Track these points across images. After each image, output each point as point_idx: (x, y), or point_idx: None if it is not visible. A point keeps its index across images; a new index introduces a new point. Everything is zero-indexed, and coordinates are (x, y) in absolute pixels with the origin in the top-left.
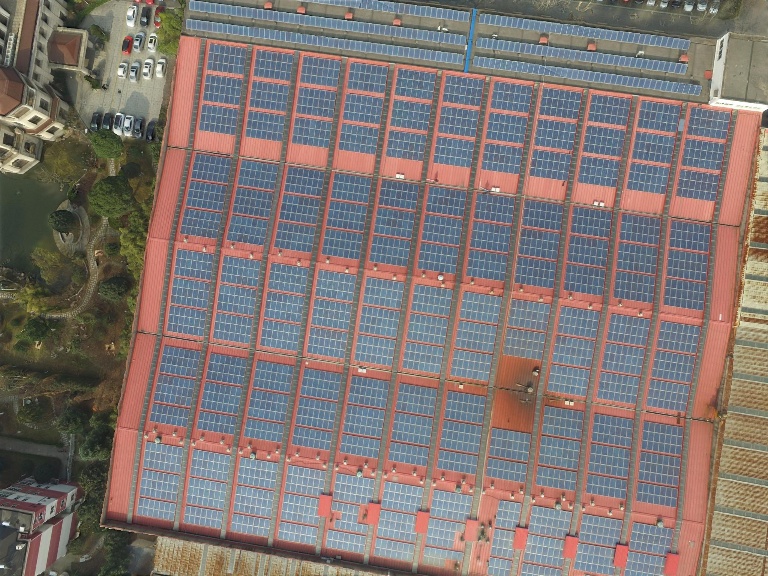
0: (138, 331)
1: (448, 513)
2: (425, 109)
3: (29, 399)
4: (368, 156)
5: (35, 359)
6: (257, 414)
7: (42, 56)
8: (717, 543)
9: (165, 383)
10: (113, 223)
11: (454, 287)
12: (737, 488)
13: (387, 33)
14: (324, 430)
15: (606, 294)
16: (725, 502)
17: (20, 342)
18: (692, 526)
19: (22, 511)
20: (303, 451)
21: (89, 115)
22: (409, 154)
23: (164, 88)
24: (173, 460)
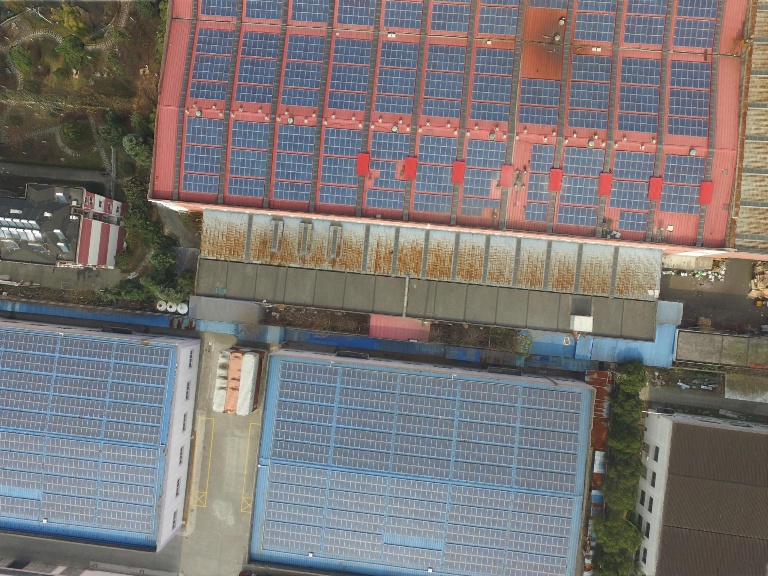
0: (173, 17)
1: (483, 161)
2: None
3: None
4: None
5: None
6: (292, 83)
7: None
8: (750, 170)
9: (202, 62)
10: None
11: None
12: (767, 114)
13: None
14: (358, 93)
15: None
16: (756, 130)
17: (59, 68)
18: (724, 154)
19: None
20: (339, 114)
21: None
22: None
23: None
24: (214, 133)
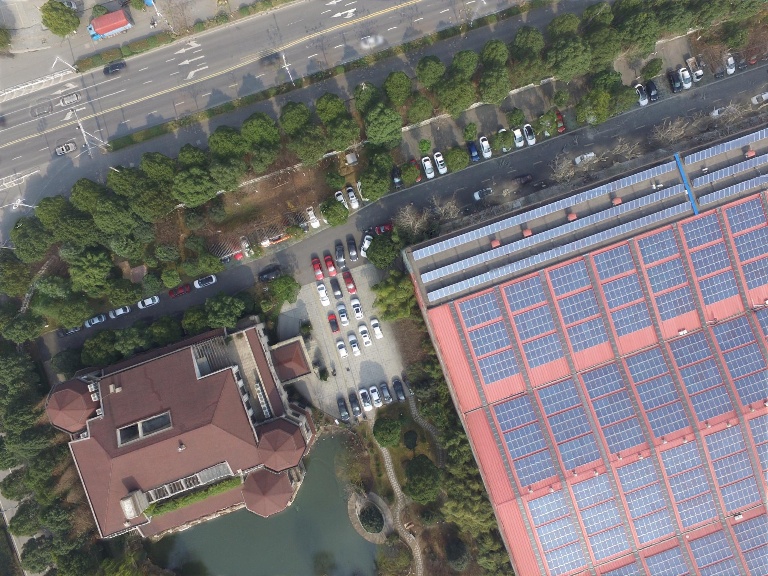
0: None
1: None
2: (677, 264)
3: None
4: (646, 329)
5: None
6: None
7: (278, 383)
8: None
9: None
10: None
11: None
12: None
13: (612, 214)
14: None
15: None
16: None
17: None
18: None
19: None
20: None
21: (331, 406)
22: (681, 309)
23: (398, 350)
24: None
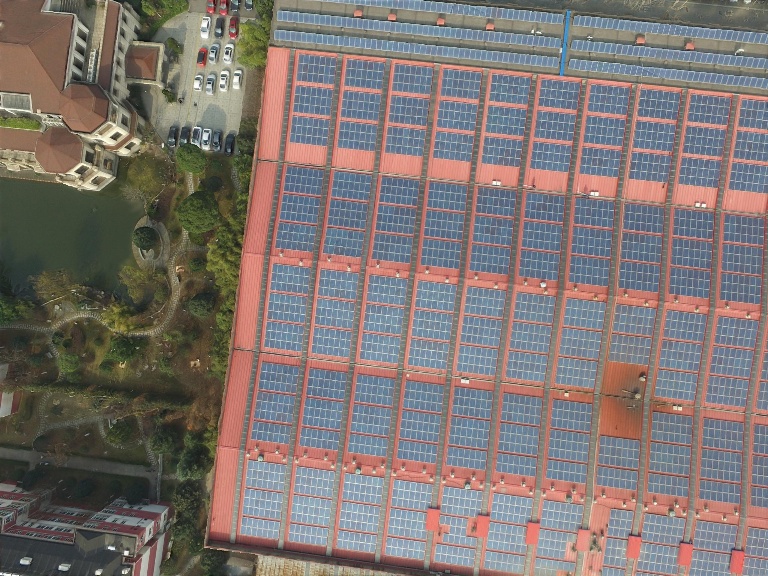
0: (234, 348)
1: (559, 523)
2: (521, 114)
3: None
4: (463, 163)
5: (119, 378)
6: (360, 429)
7: (120, 71)
8: None
9: (265, 400)
10: (194, 238)
11: (557, 294)
12: None
13: (480, 38)
14: (429, 443)
15: (712, 296)
16: None
17: (105, 362)
18: None
19: (126, 534)
20: (409, 465)
21: (165, 129)
22: (505, 160)
23: (243, 100)
24: (276, 478)
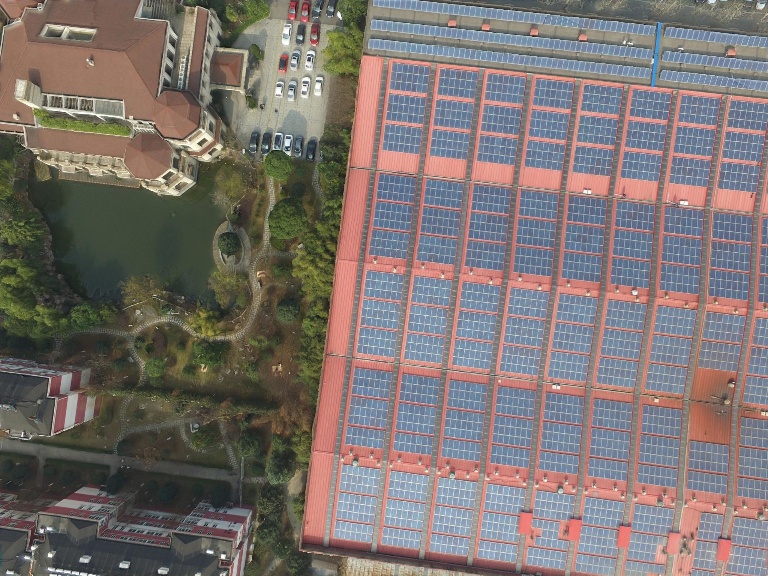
0: (327, 354)
1: (650, 527)
2: (612, 124)
3: (197, 423)
4: (554, 172)
5: (201, 383)
6: (453, 434)
7: (206, 77)
8: None
9: (358, 405)
10: (276, 244)
11: (648, 301)
12: None
13: (572, 49)
14: (522, 448)
15: None
16: None
17: (189, 366)
18: None
19: (222, 538)
20: (502, 469)
21: (246, 135)
22: (596, 169)
23: (327, 107)
24: (370, 482)
